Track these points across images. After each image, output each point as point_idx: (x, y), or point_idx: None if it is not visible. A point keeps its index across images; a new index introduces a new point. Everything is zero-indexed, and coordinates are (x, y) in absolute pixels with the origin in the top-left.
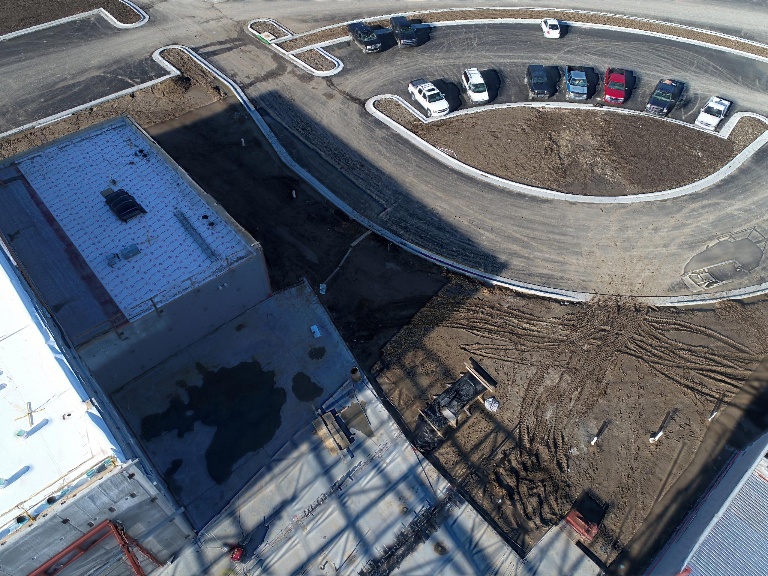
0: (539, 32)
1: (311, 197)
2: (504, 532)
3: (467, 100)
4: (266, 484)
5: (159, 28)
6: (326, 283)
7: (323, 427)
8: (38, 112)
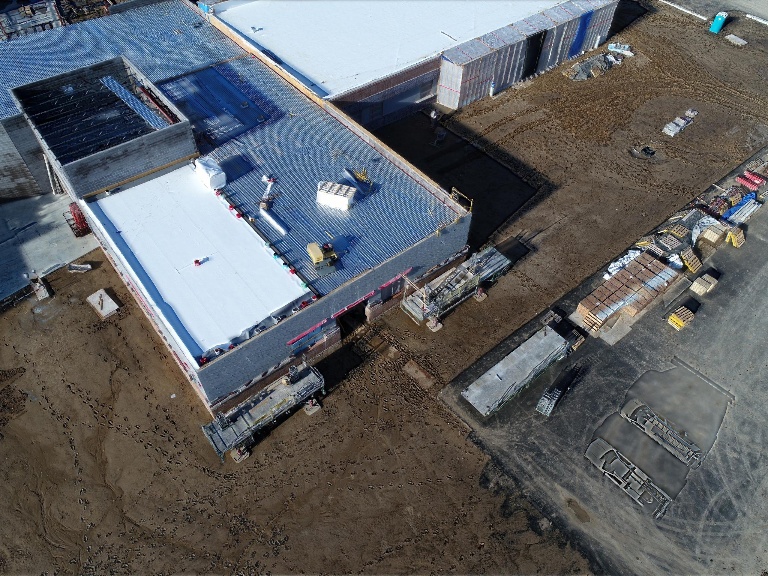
0: None
1: None
2: None
3: None
4: None
5: None
6: None
7: (22, 9)
8: None
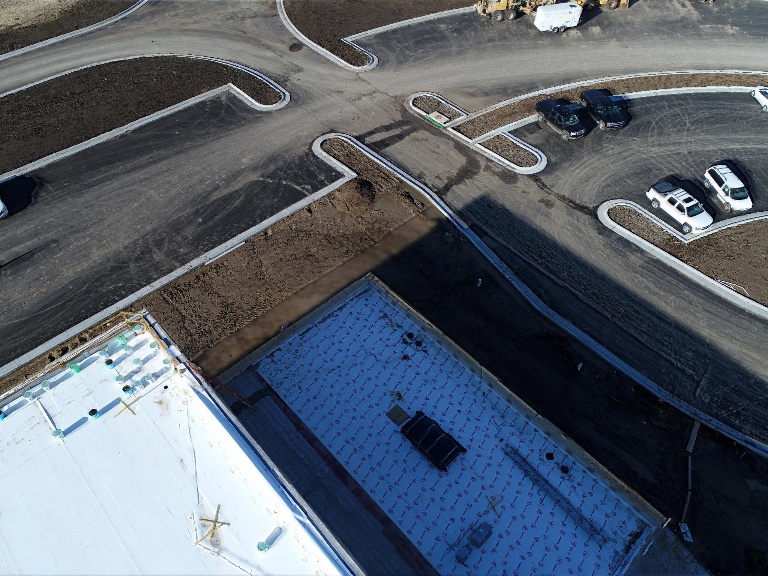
0: (754, 104)
1: (596, 366)
2: None
3: (720, 206)
4: None
5: (306, 109)
6: (685, 521)
7: None
8: (201, 240)
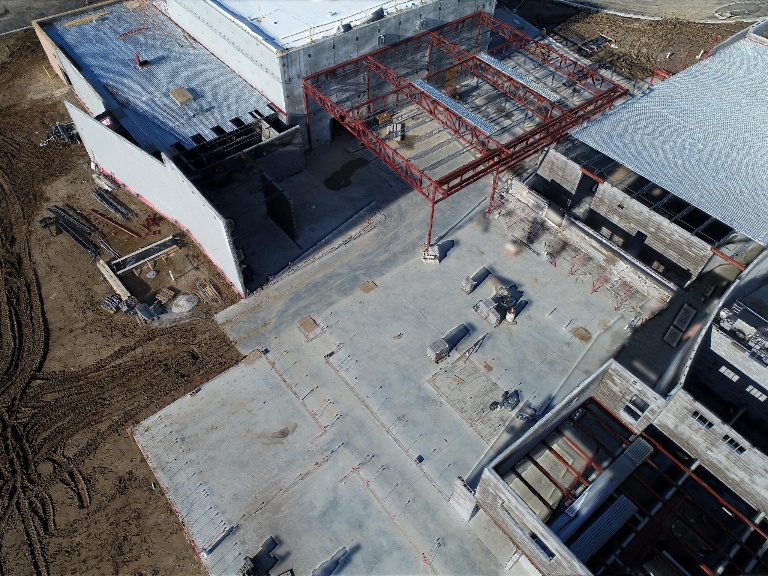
0: None
1: None
2: (627, 78)
3: None
4: (510, 61)
5: None
6: (516, 9)
7: (532, 47)
8: None
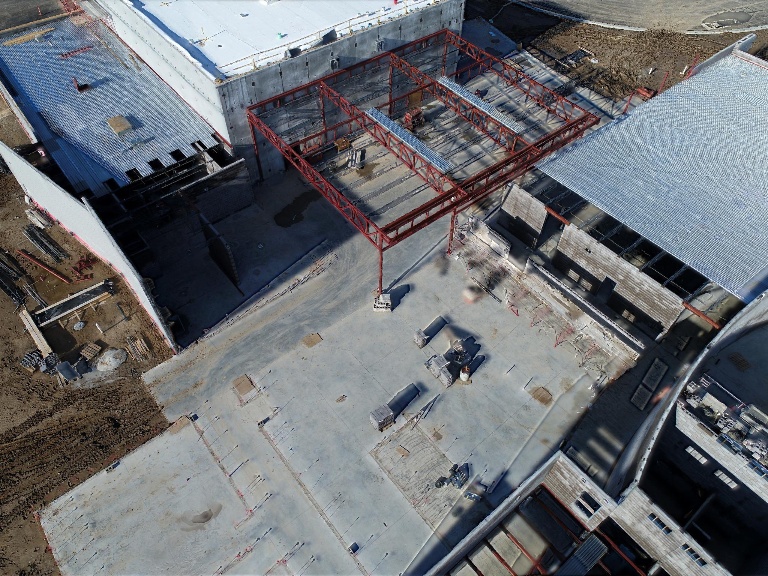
0: None
1: None
2: None
3: None
4: (483, 78)
5: None
6: (492, 19)
7: (507, 62)
8: None
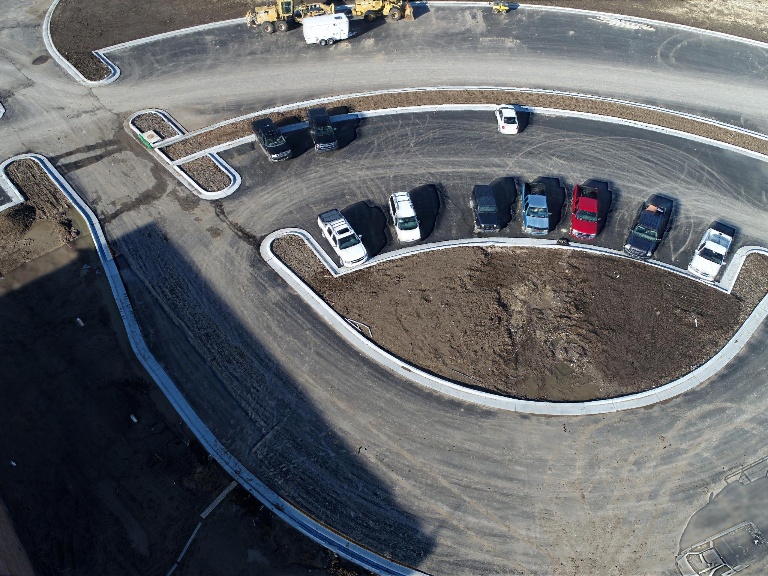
0: (493, 124)
1: (161, 417)
2: None
3: (394, 236)
4: None
5: (14, 127)
6: None
7: None
8: None
